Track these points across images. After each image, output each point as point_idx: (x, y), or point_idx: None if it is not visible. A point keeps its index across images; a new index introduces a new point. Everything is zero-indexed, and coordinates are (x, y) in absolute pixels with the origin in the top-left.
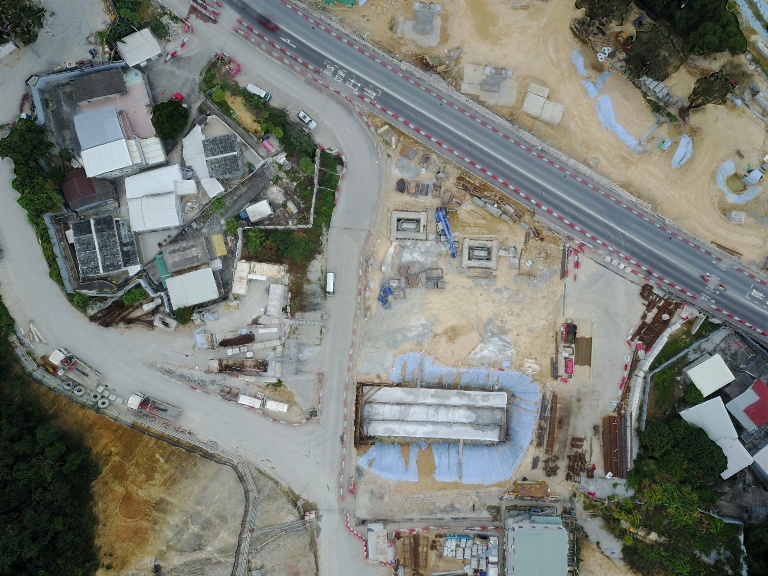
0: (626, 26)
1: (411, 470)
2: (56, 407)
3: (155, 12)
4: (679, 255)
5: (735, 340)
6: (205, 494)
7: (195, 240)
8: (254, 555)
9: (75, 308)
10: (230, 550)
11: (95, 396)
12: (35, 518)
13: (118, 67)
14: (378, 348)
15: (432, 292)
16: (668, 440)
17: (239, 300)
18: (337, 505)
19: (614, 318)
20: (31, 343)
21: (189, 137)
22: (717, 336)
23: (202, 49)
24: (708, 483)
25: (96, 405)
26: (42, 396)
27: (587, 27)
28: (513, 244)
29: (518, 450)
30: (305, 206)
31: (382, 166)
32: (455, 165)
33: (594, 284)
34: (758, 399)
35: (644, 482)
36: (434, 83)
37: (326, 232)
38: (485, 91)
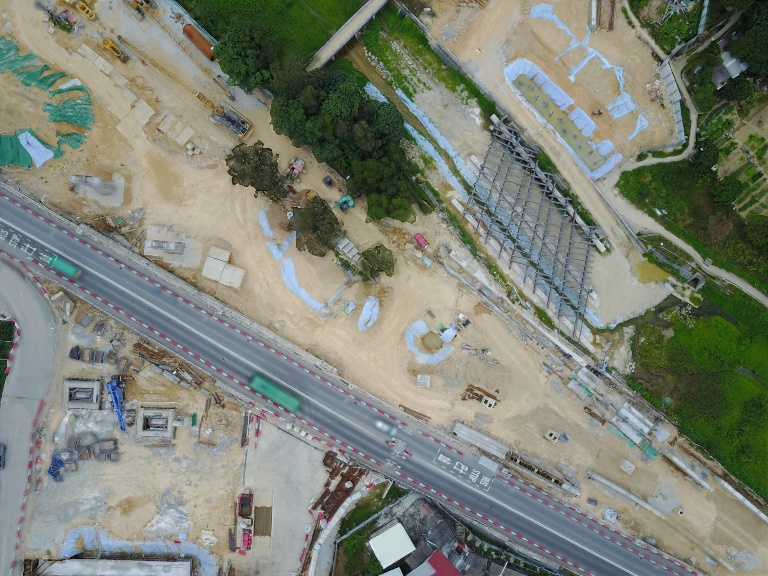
0: (318, 184)
1: None
2: None
3: None
4: (364, 420)
5: (424, 505)
6: None
7: None
8: None
9: None
10: None
11: None
12: None
13: None
14: (49, 522)
15: (107, 463)
16: None
17: None
18: None
19: (296, 486)
20: None
21: None
22: (408, 500)
23: None
24: None
25: None
26: None
27: None
28: (194, 411)
29: None
30: None
31: (57, 333)
32: (134, 331)
33: (276, 451)
34: (435, 572)
35: None
36: (113, 246)
37: None
38: (169, 253)
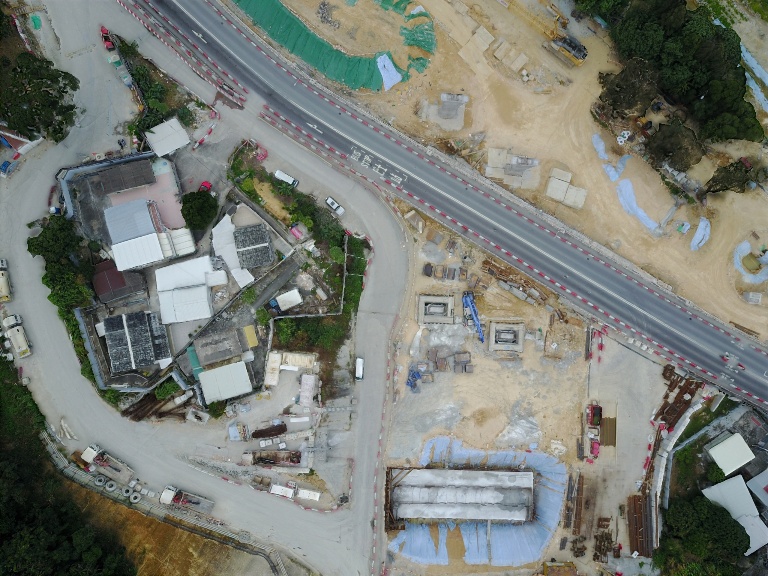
0: None
1: (441, 553)
2: (88, 505)
3: (182, 99)
4: (699, 335)
5: (753, 417)
6: None
7: (227, 333)
8: None
9: (106, 403)
10: None
11: (127, 491)
12: None
13: (146, 157)
14: (407, 432)
15: (460, 375)
16: (692, 520)
17: (270, 390)
18: None
19: (637, 398)
20: (62, 440)
21: (219, 227)
22: (736, 413)
23: (229, 135)
24: (732, 562)
25: (128, 500)
26: (74, 494)
27: (607, 111)
28: (538, 326)
29: (546, 531)
30: (334, 293)
31: (409, 251)
32: (481, 249)
33: (618, 365)
34: None
35: (669, 561)
36: (459, 168)
37: (354, 316)
38: (509, 175)
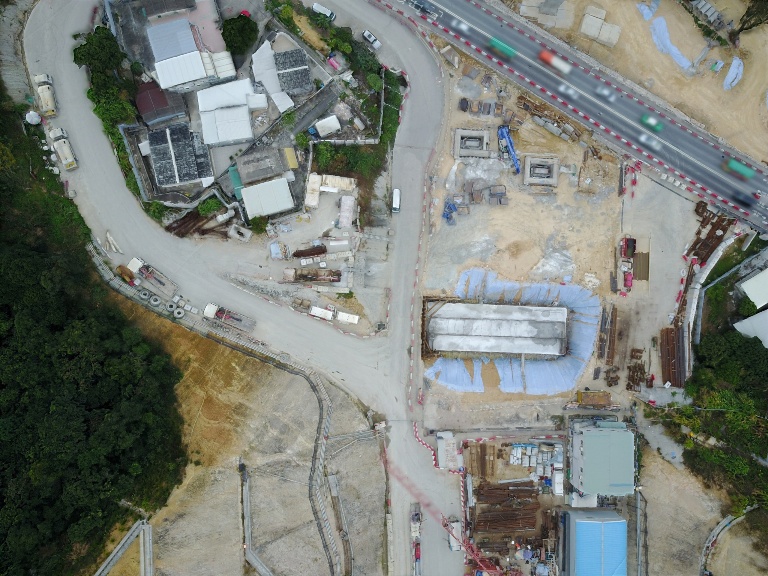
0: None
1: (476, 382)
2: (134, 315)
3: None
4: (731, 173)
5: None
6: (281, 401)
7: (269, 151)
8: (329, 461)
9: (151, 218)
10: (307, 455)
11: (171, 306)
12: (130, 410)
13: None
14: (443, 263)
15: (495, 209)
16: (725, 349)
17: (310, 213)
18: (405, 416)
19: (670, 234)
20: (108, 253)
21: (259, 53)
22: (767, 252)
23: None
24: (764, 389)
25: (172, 315)
26: (120, 304)
27: None
28: (572, 162)
29: (579, 362)
30: (371, 123)
31: (445, 86)
32: (516, 85)
33: (651, 201)
34: None
35: (702, 390)
36: (494, 5)
37: (391, 150)
38: (543, 14)
